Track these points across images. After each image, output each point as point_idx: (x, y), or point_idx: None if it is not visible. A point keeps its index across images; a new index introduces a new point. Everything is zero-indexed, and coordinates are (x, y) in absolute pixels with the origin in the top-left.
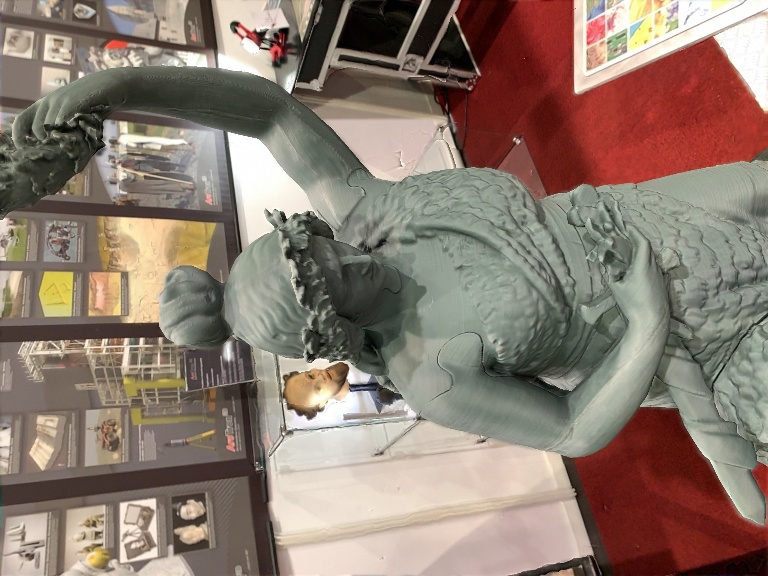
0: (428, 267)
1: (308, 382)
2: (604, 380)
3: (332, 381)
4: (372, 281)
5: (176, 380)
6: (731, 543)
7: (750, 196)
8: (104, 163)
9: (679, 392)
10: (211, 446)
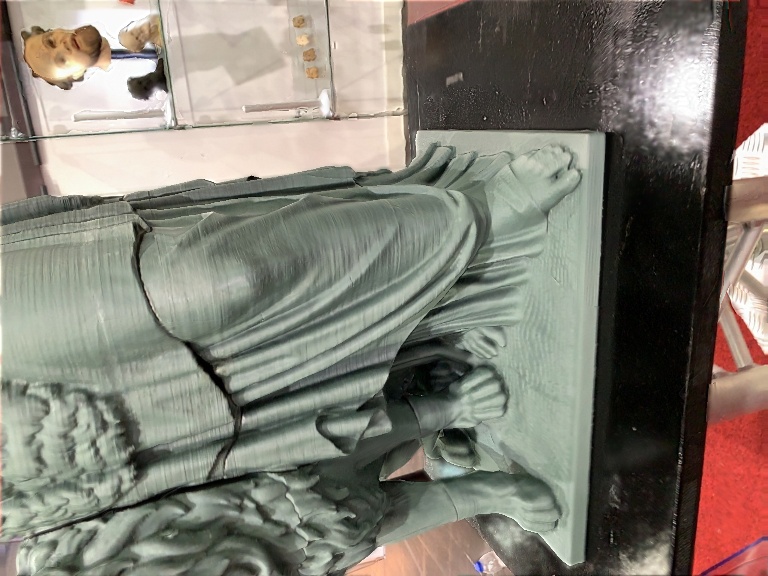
0: None
1: (45, 52)
2: None
3: (80, 52)
4: None
5: None
6: None
7: (91, 353)
8: None
9: None
10: None
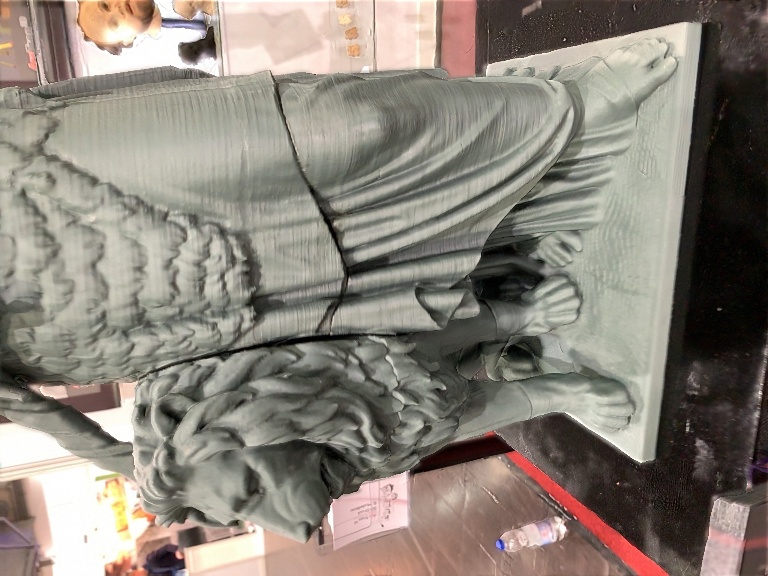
0: None
1: (100, 15)
2: None
3: (134, 17)
4: None
5: None
6: None
7: (232, 182)
8: None
9: None
10: (9, 62)
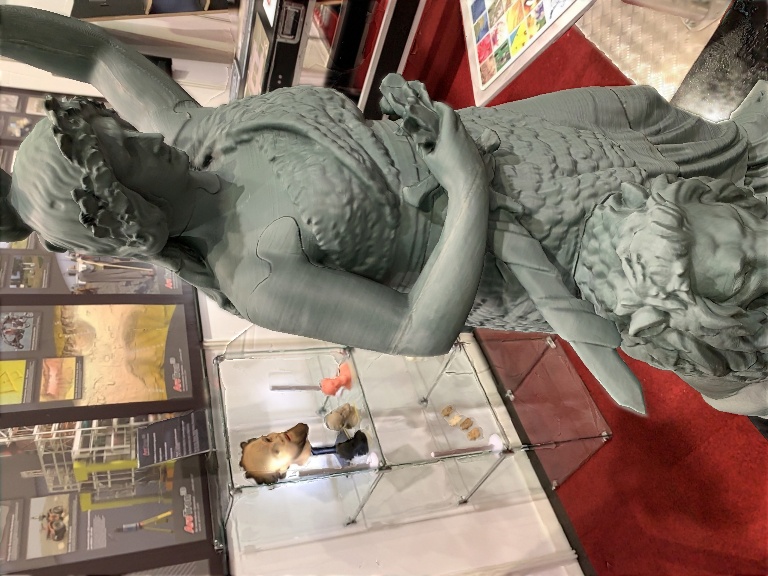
0: (246, 168)
1: (265, 445)
2: (435, 258)
3: (291, 443)
4: (171, 164)
5: (130, 461)
6: None
7: (591, 107)
8: (64, 257)
9: (520, 269)
10: (167, 528)
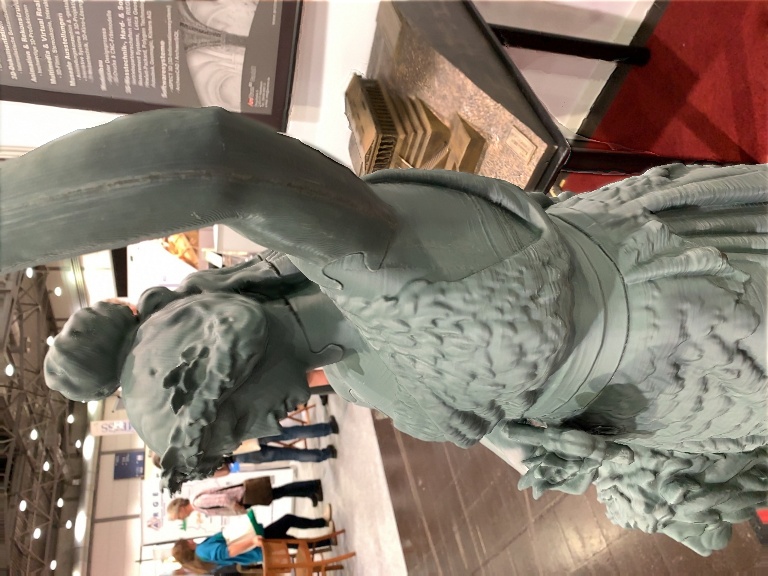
0: (375, 369)
1: None
2: (489, 436)
3: None
4: None
5: None
6: (738, 127)
7: None
8: None
9: None
10: None
